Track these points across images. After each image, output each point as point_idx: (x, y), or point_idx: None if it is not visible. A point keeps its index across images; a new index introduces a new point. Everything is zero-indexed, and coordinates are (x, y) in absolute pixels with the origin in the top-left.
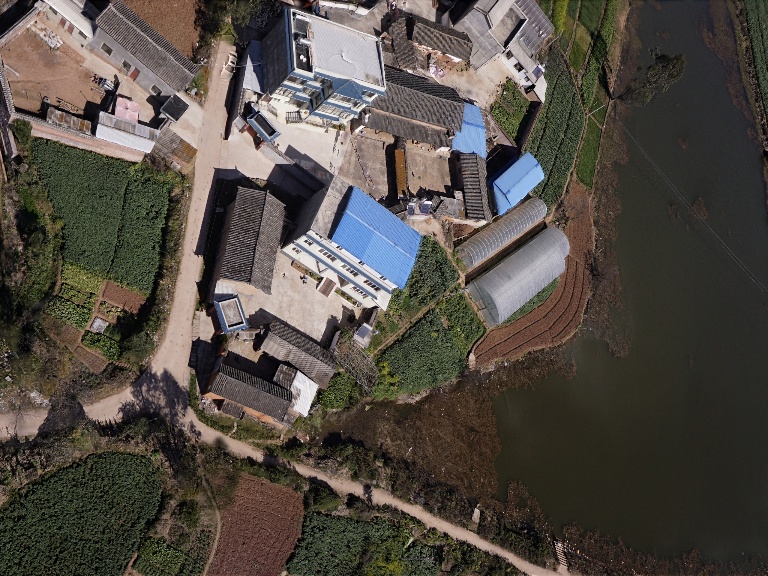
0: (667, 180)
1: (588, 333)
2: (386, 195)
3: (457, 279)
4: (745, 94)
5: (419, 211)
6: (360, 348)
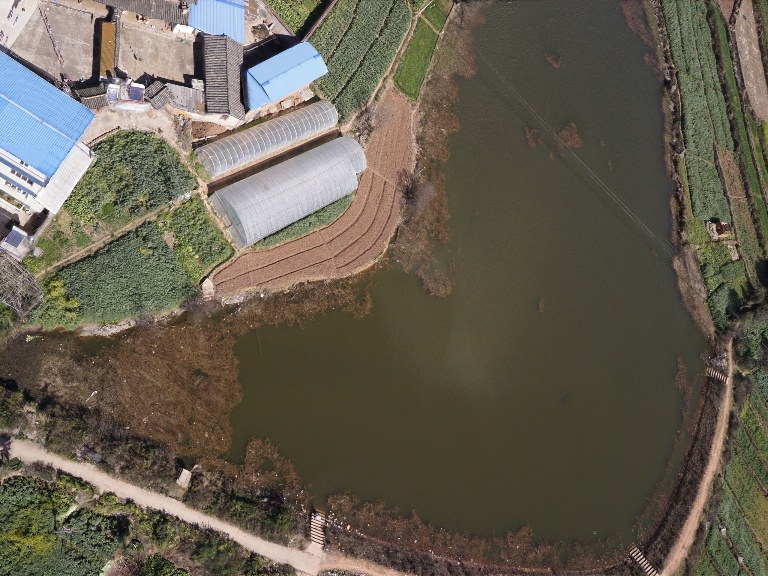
0: (516, 94)
1: (394, 265)
2: (88, 78)
3: (194, 188)
4: (645, 17)
5: (127, 97)
6: (12, 260)
